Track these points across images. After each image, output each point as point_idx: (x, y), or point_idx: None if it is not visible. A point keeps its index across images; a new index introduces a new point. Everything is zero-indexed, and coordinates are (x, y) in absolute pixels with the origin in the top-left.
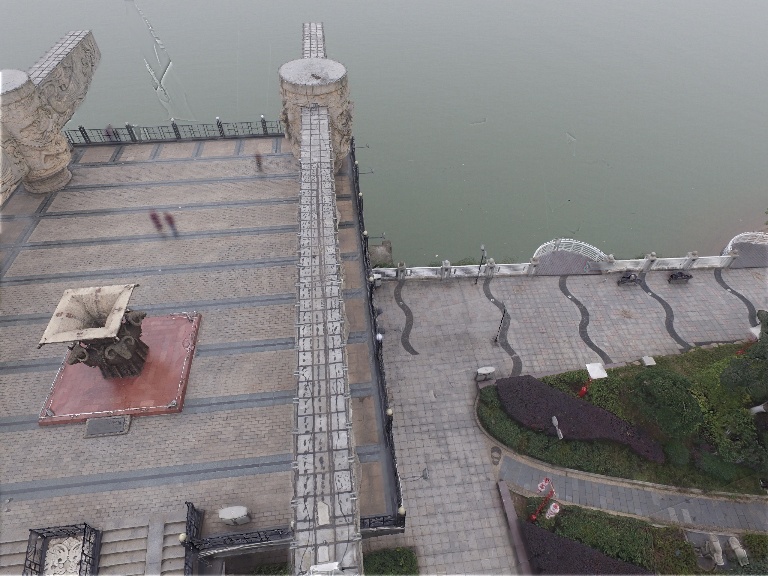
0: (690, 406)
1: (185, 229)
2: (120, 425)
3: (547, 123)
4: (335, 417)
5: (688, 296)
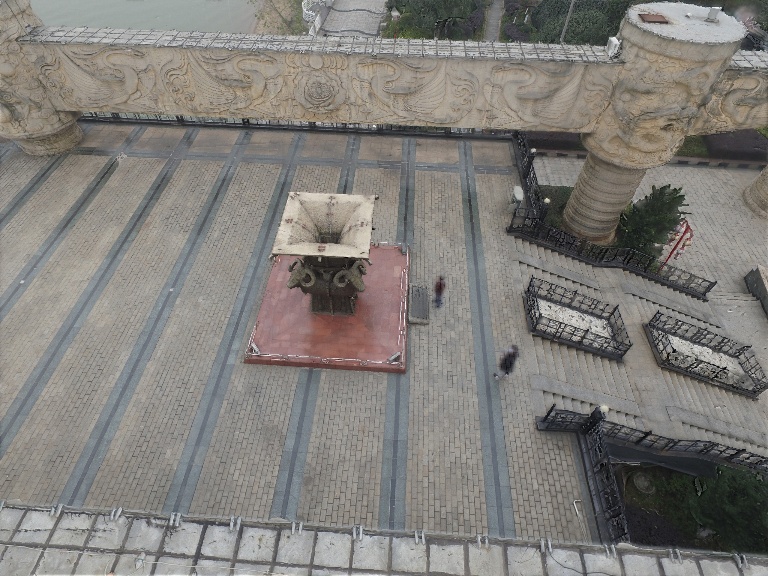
0: None
1: (90, 270)
2: (420, 290)
3: (124, 7)
4: (510, 46)
5: None
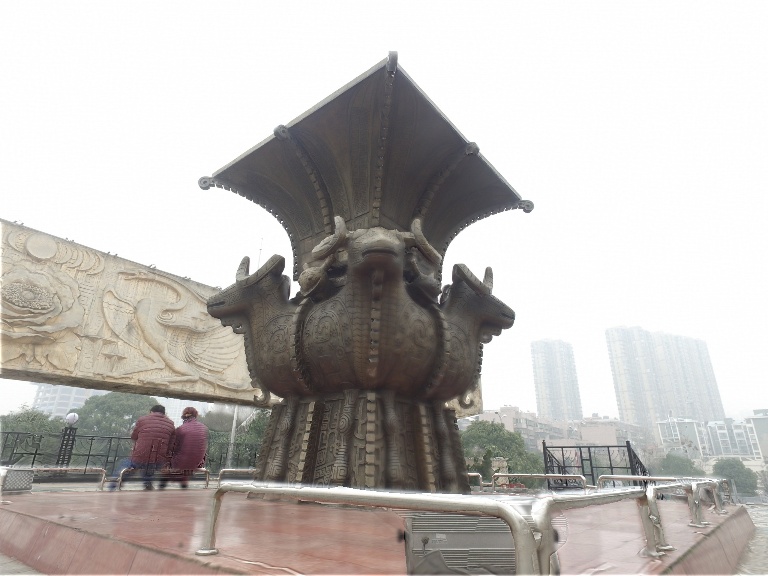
0: None
1: None
2: None
3: None
4: None
5: None
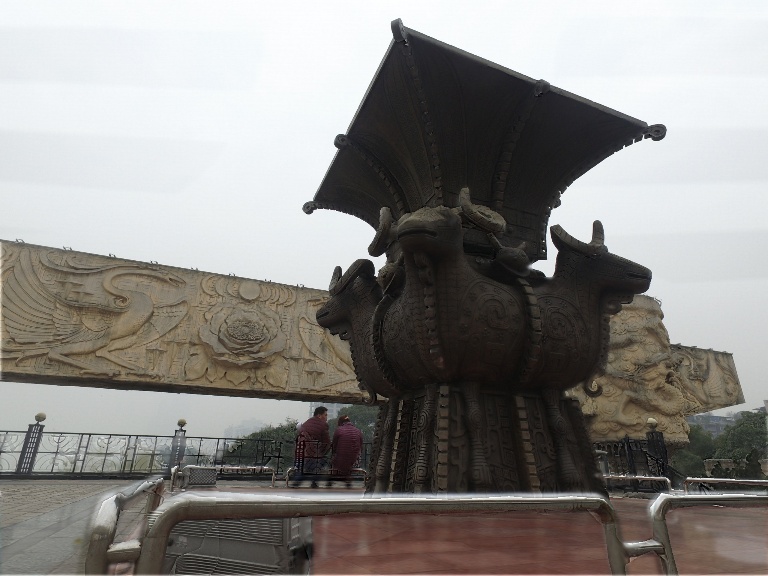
0: None
1: None
2: None
3: None
4: None
5: None
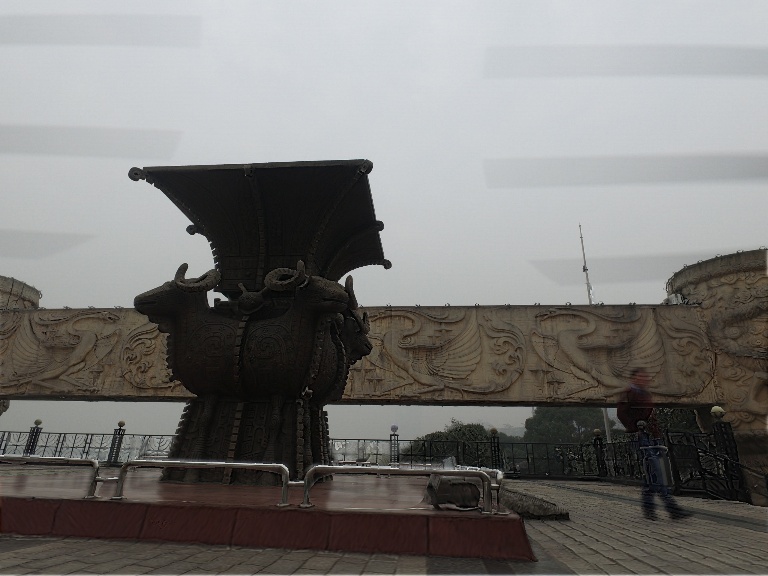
0: None
1: None
2: None
3: None
4: None
5: None
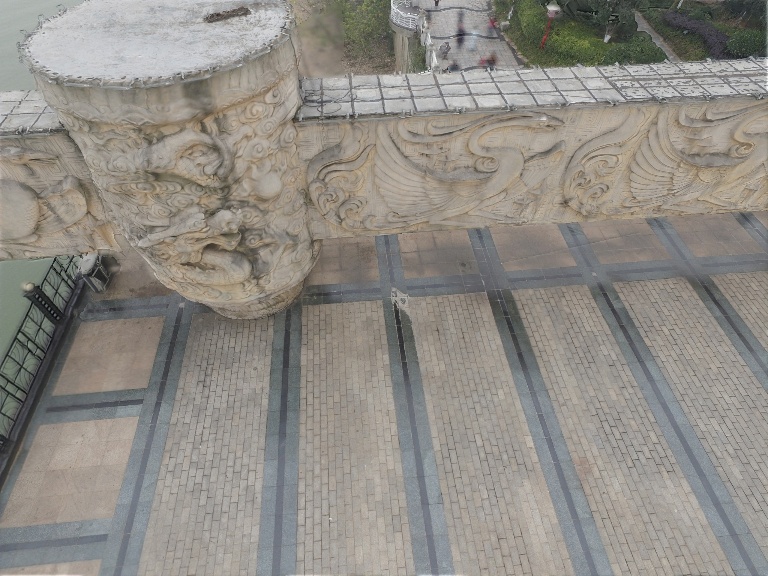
0: (652, 46)
1: None
2: None
3: None
4: None
5: (462, 55)
